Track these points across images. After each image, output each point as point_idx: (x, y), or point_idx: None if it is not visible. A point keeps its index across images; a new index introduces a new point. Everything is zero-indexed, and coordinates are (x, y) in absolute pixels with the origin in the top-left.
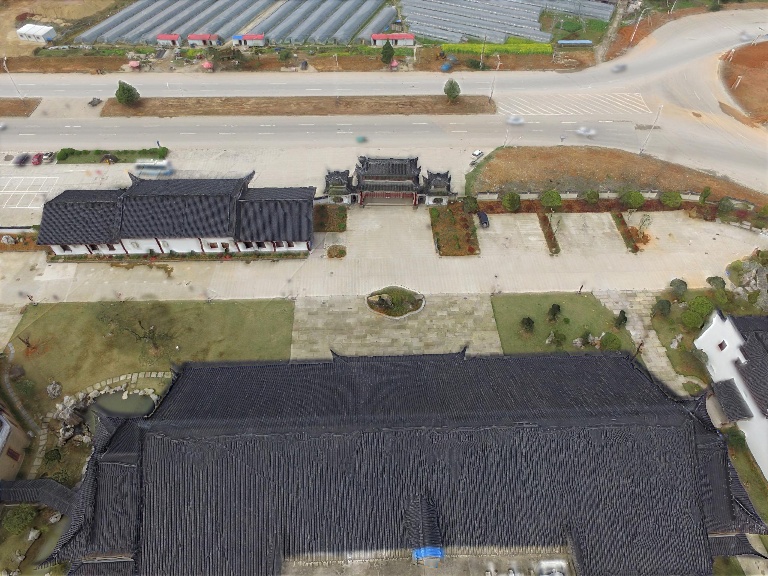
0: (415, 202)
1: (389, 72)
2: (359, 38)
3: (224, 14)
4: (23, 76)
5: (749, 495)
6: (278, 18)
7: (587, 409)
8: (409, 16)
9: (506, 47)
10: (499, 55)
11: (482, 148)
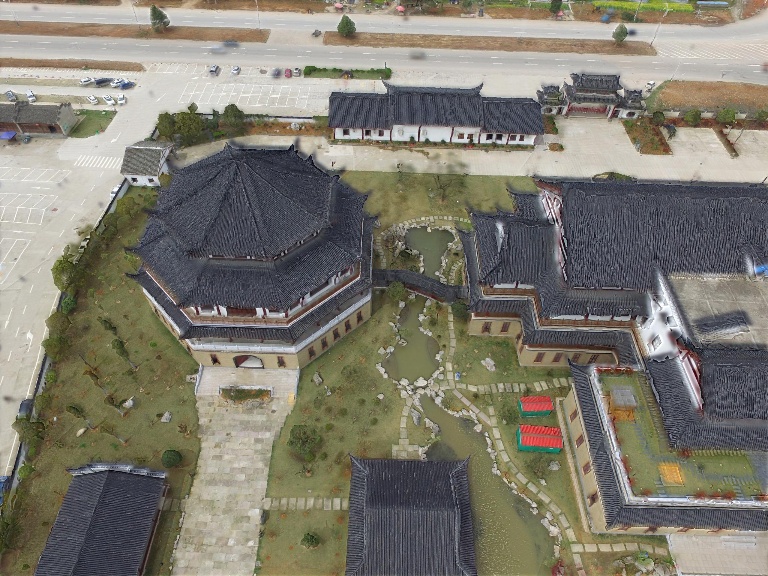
0: (611, 115)
1: (554, 21)
2: None
3: None
4: (246, 12)
5: None
6: None
7: None
8: None
9: (652, 5)
10: (647, 11)
11: None
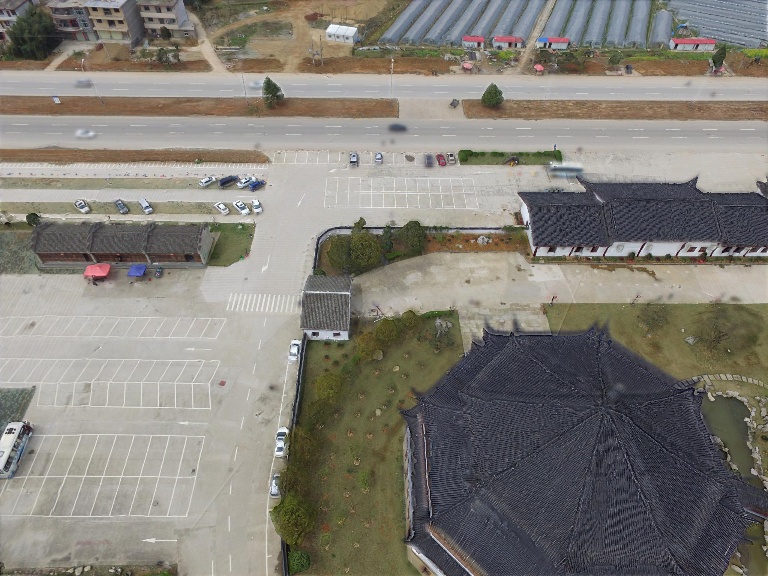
0: None
1: (714, 77)
2: (658, 42)
3: (507, 16)
4: (361, 77)
5: None
6: (563, 21)
7: None
8: (691, 20)
9: None
10: None
11: None
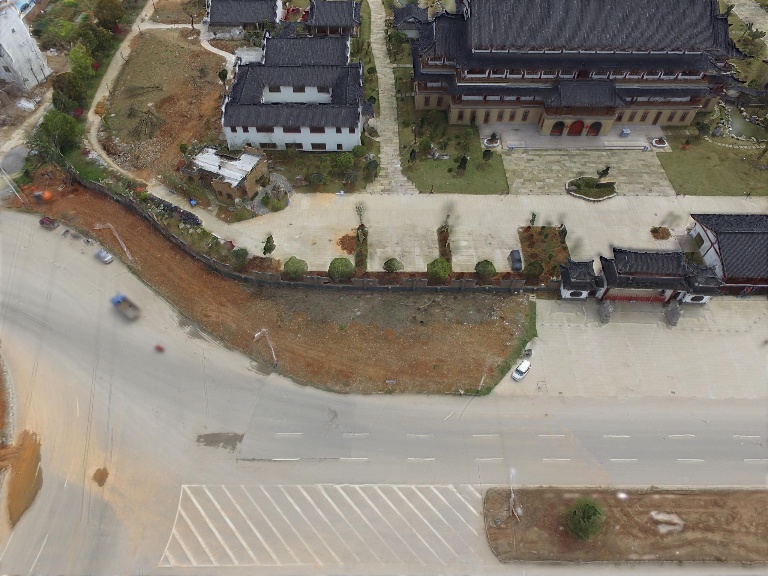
0: None
1: None
2: None
3: None
4: None
5: (374, 95)
6: None
7: (513, 1)
8: None
9: None
10: None
11: (513, 392)
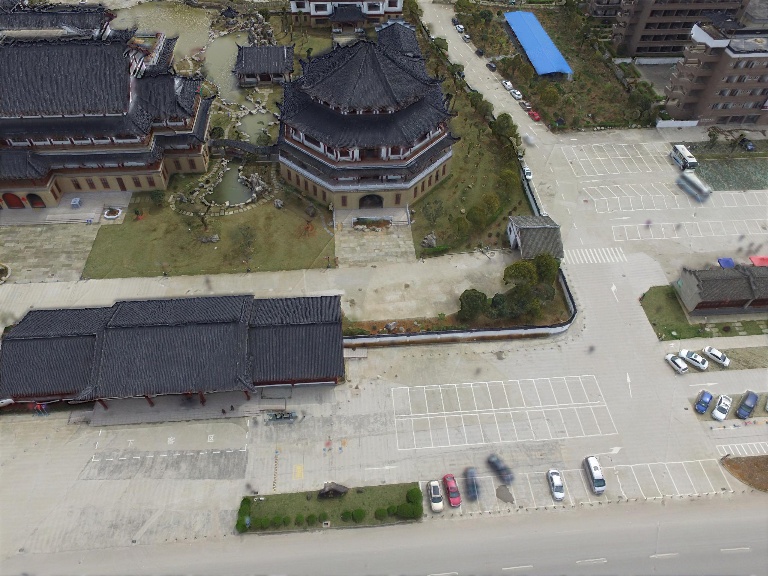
0: None
1: None
2: None
3: None
4: None
5: None
6: None
7: None
8: None
9: None
10: None
11: None
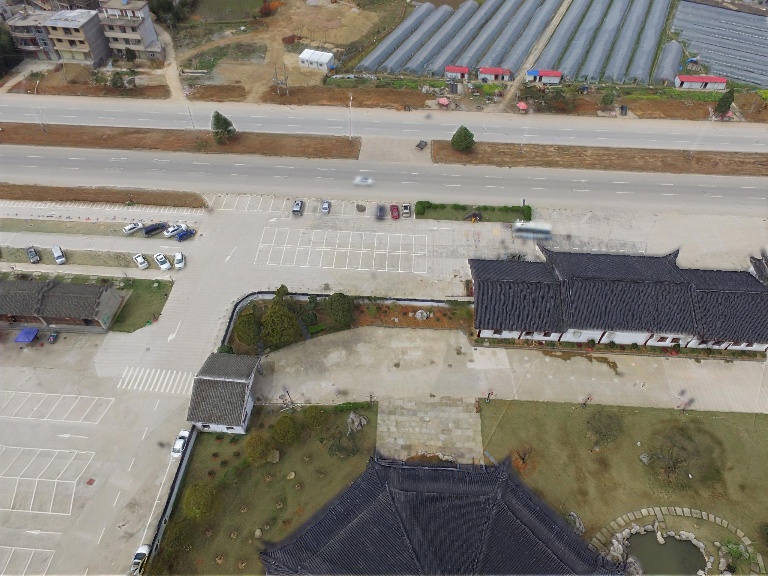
0: None
1: (720, 122)
2: (662, 78)
3: (499, 44)
4: (327, 109)
5: None
6: (560, 51)
7: None
8: (703, 54)
9: None
10: None
11: None
